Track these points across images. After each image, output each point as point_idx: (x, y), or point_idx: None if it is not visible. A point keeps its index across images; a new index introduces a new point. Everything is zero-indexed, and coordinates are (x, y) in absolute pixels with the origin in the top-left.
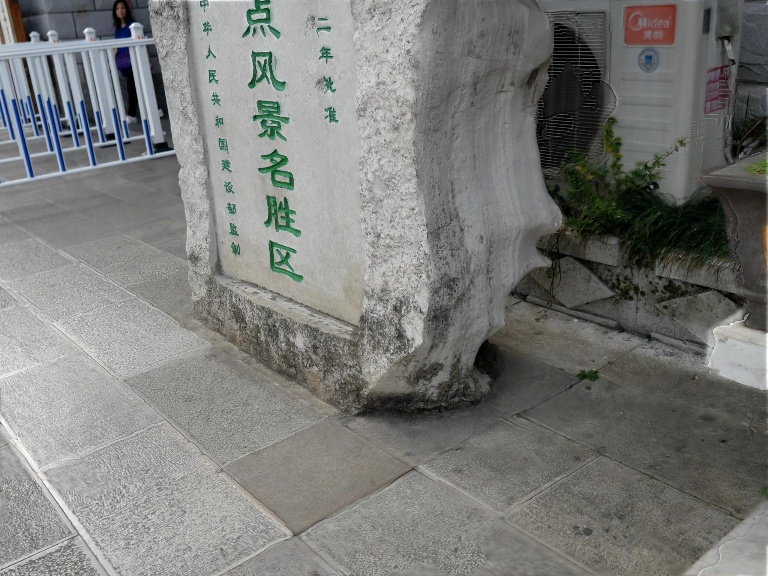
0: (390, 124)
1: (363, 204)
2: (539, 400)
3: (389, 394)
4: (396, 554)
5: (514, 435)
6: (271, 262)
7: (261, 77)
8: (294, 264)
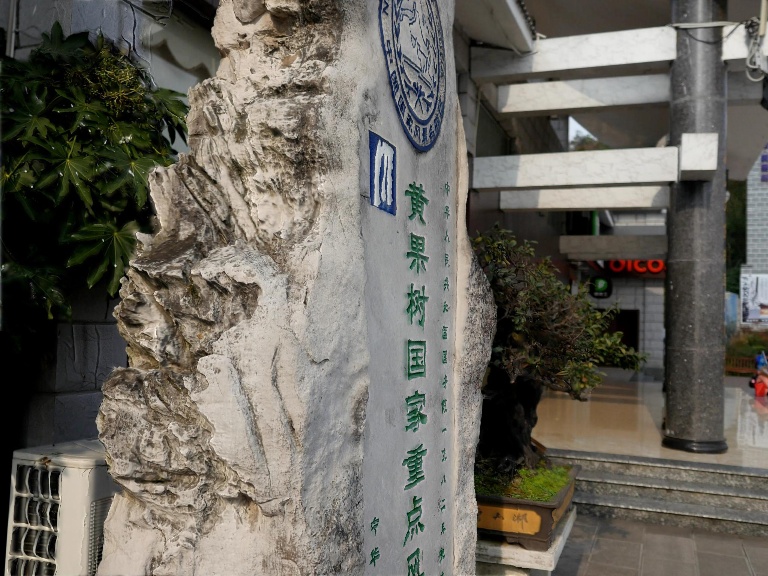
0: None
1: None
2: None
3: None
4: None
5: None
6: None
7: None
8: None
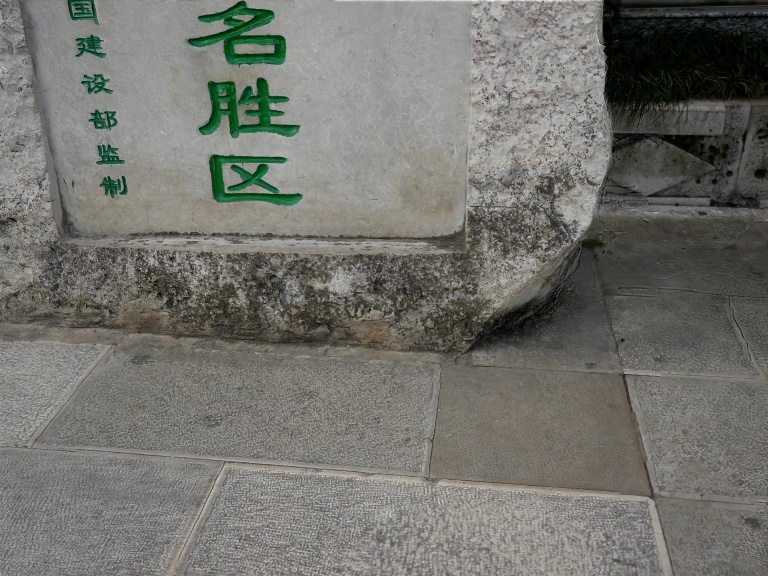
0: None
1: (478, 56)
2: (591, 274)
3: (522, 306)
4: (763, 457)
5: (648, 307)
6: (214, 189)
7: None
8: (280, 180)
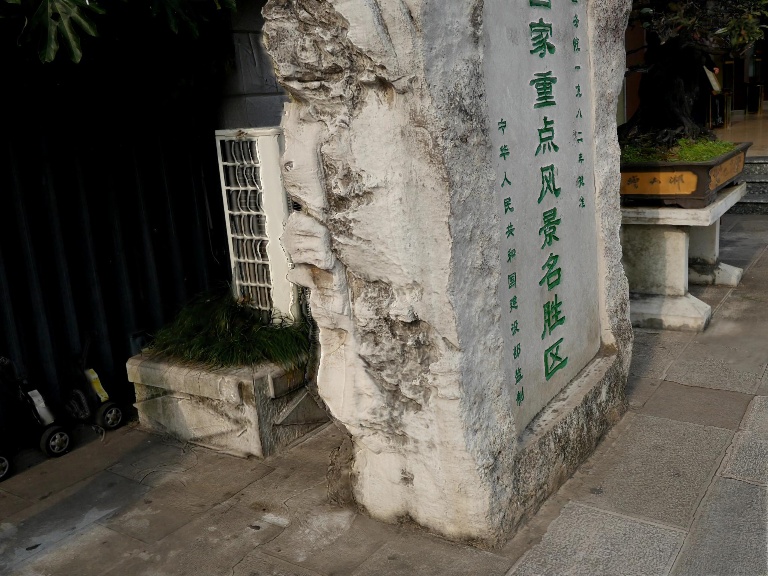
0: None
1: None
2: None
3: None
4: None
5: None
6: None
7: None
8: None
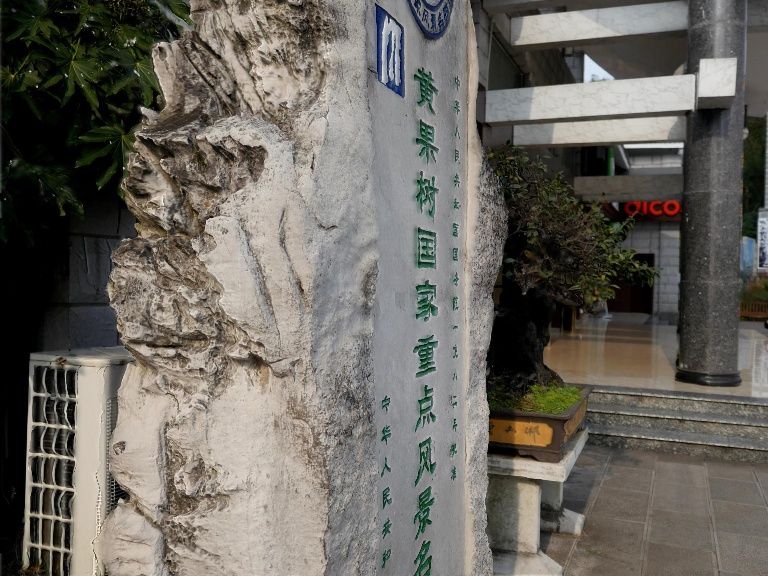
0: (483, 456)
1: None
2: None
3: None
4: None
5: None
6: None
7: None
8: None
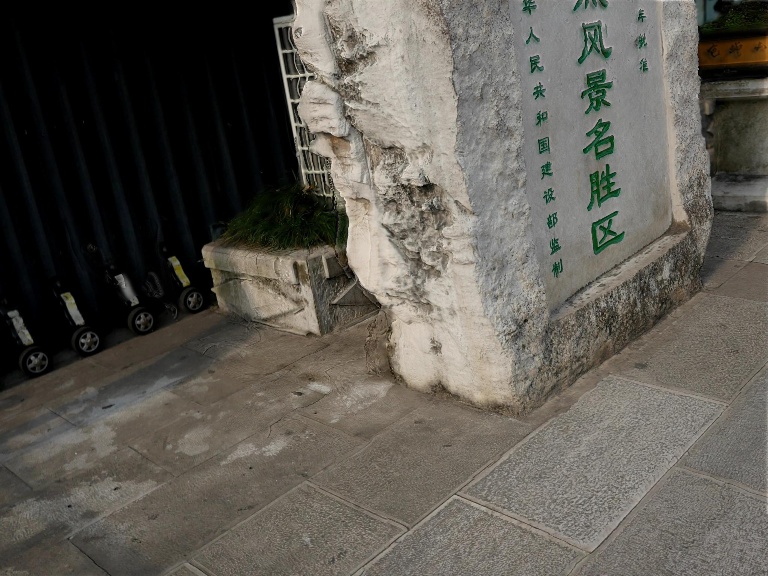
0: (689, 54)
1: None
2: None
3: None
4: None
5: None
6: None
7: (591, 48)
8: (617, 226)
